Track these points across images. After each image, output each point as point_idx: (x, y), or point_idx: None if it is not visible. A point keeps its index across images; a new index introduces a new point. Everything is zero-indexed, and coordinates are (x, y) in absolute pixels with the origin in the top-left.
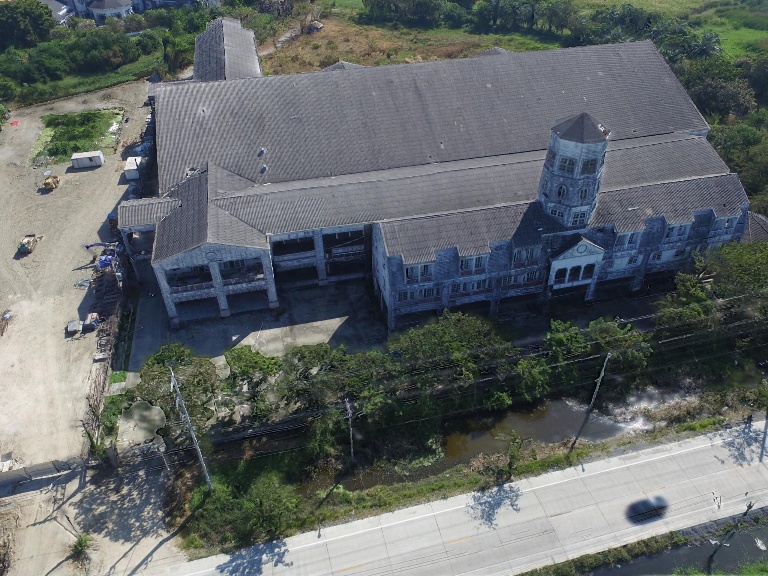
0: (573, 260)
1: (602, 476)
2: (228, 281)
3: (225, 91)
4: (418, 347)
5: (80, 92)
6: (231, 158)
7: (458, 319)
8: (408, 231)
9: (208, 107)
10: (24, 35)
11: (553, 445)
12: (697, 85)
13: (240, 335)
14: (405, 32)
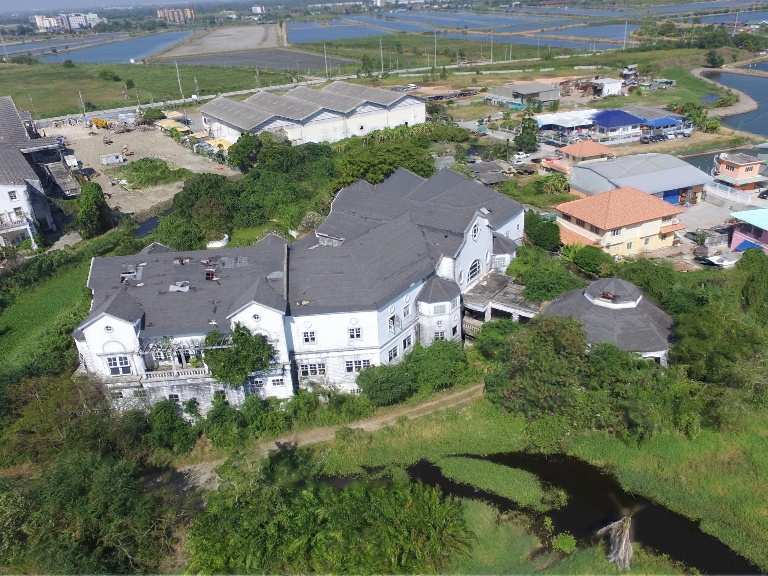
0: None
1: None
2: None
3: None
4: None
5: None
6: None
7: None
8: None
9: None
10: None
11: None
12: None
13: None
14: None
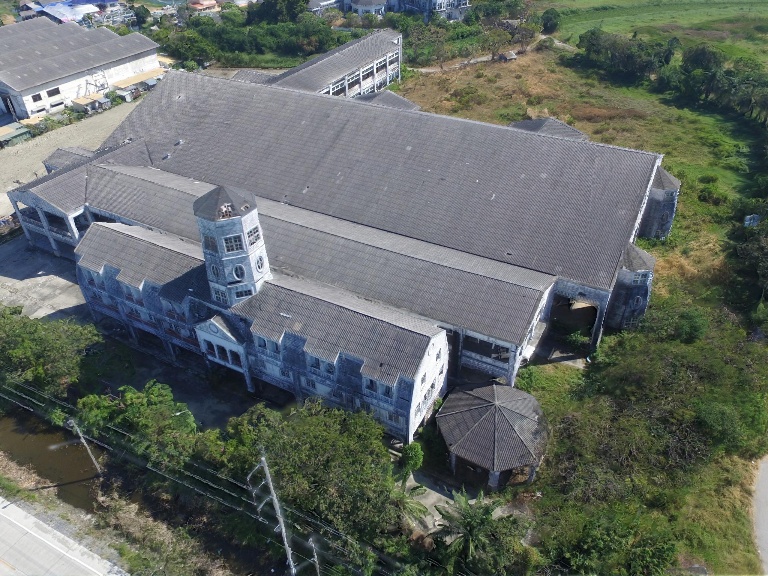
0: (213, 337)
1: (4, 522)
2: (52, 228)
3: (207, 86)
4: (6, 329)
5: (265, 67)
6: (158, 140)
7: (76, 330)
8: (104, 239)
9: (185, 95)
10: (278, 14)
11: (34, 476)
12: (754, 242)
13: (45, 273)
14: (589, 83)
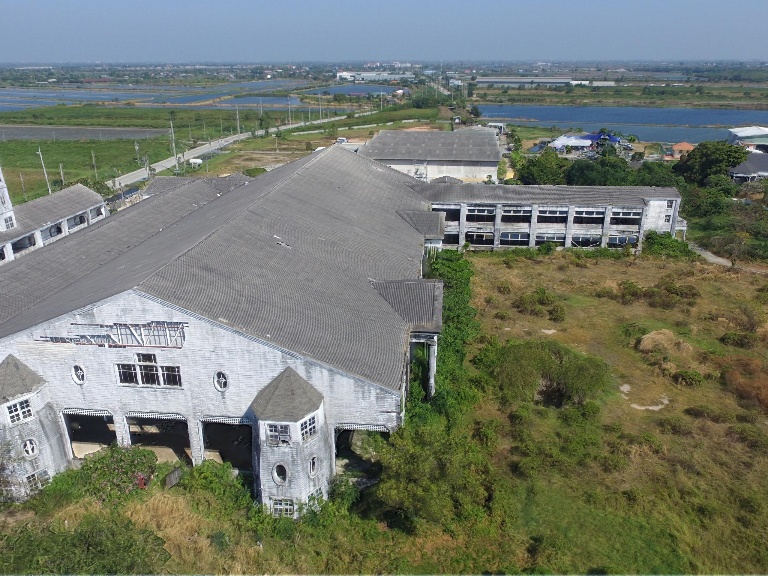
0: None
1: None
2: None
3: None
4: None
5: None
6: None
7: None
8: None
9: None
10: None
11: None
12: None
13: None
14: None
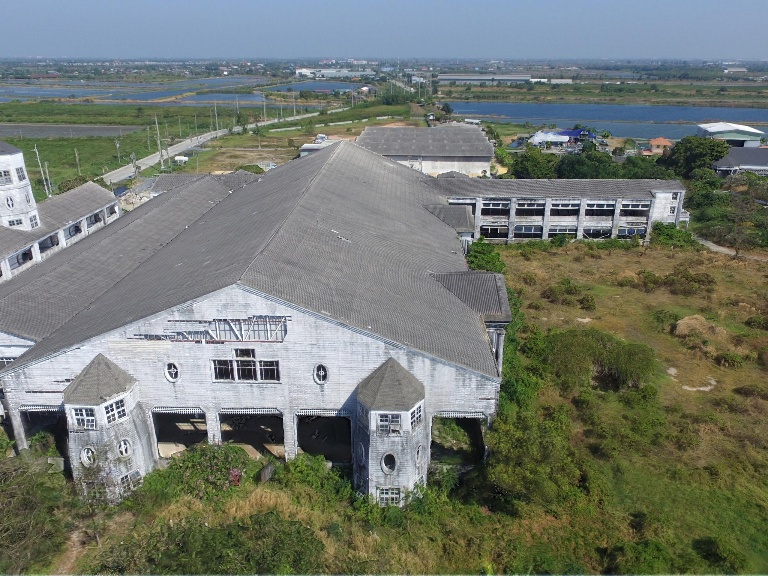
0: None
1: None
2: None
3: None
4: None
5: None
6: None
7: None
8: None
9: None
10: None
11: None
12: None
13: None
14: None
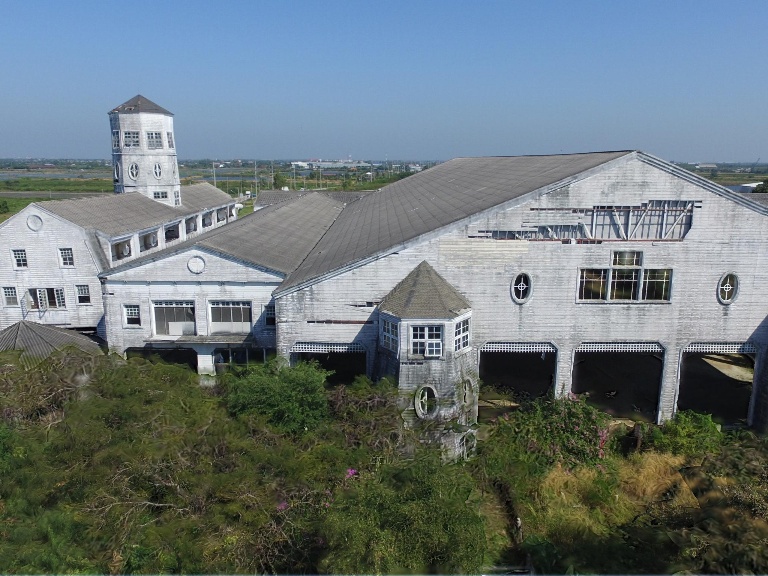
0: None
1: None
2: None
3: None
4: None
5: None
6: None
7: None
8: None
9: None
10: None
11: None
12: None
13: None
14: None
